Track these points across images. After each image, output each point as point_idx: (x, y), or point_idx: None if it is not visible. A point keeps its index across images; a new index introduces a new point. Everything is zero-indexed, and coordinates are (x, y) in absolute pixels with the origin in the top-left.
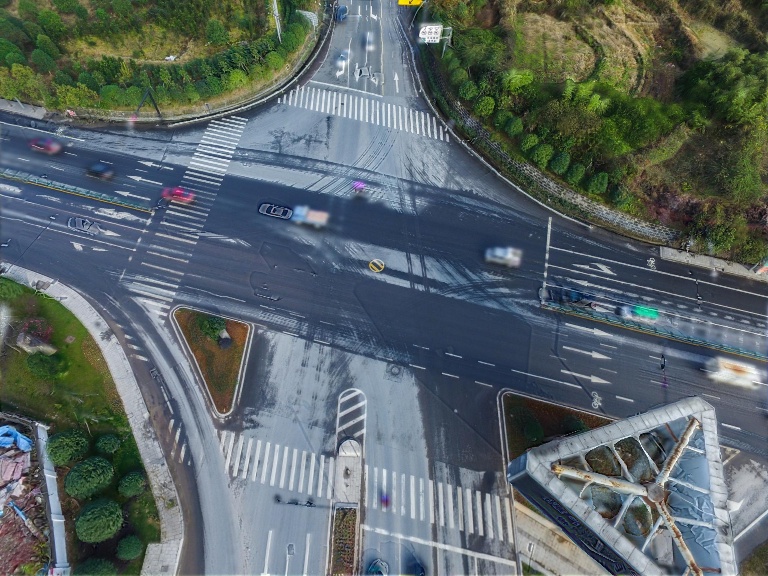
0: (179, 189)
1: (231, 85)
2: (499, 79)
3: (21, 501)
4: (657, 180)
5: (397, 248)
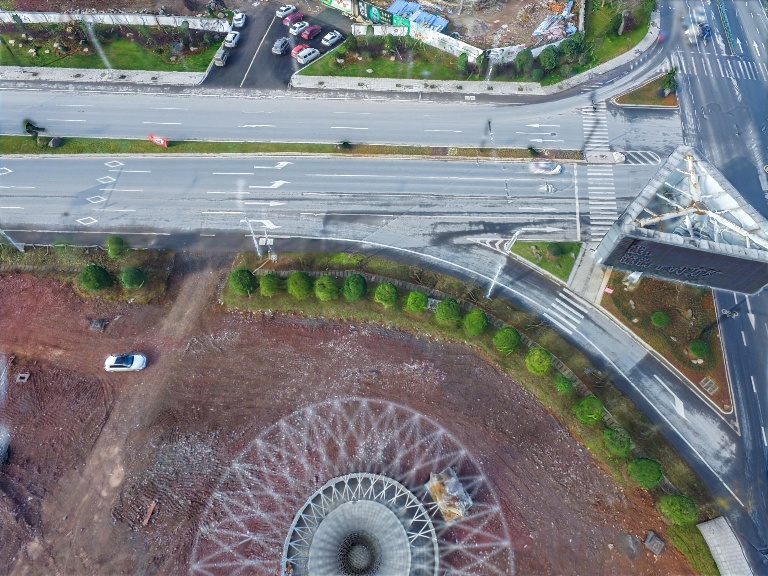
0: (762, 64)
1: None
2: None
3: (546, 39)
4: None
5: None
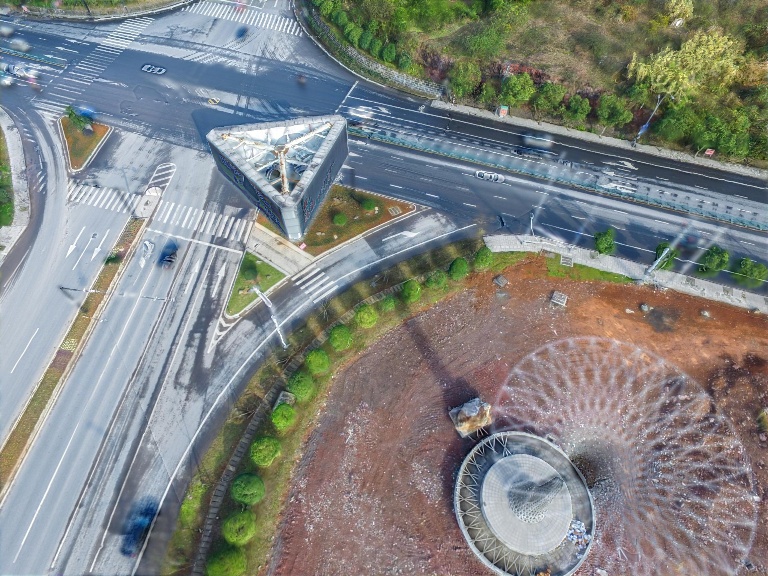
0: (89, 55)
1: None
2: None
3: None
4: (429, 48)
5: (233, 92)
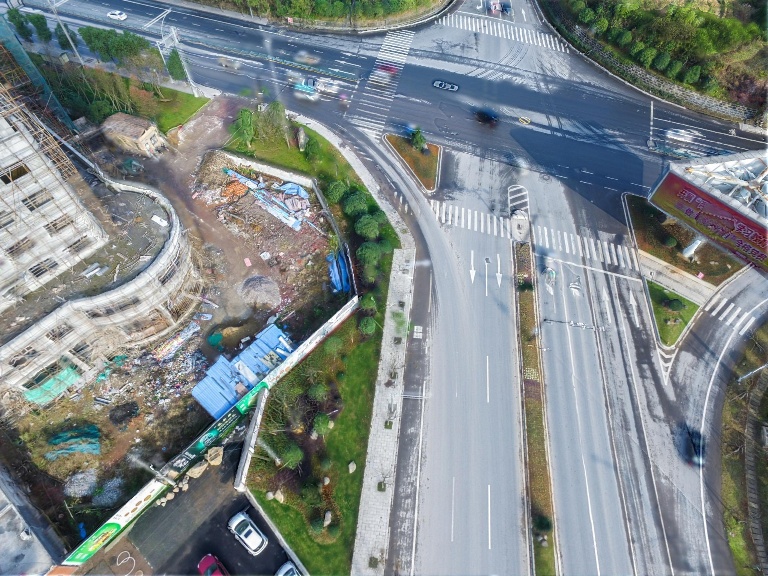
0: (373, 70)
1: (405, 6)
2: (612, 6)
3: (311, 219)
4: (739, 71)
5: (538, 111)
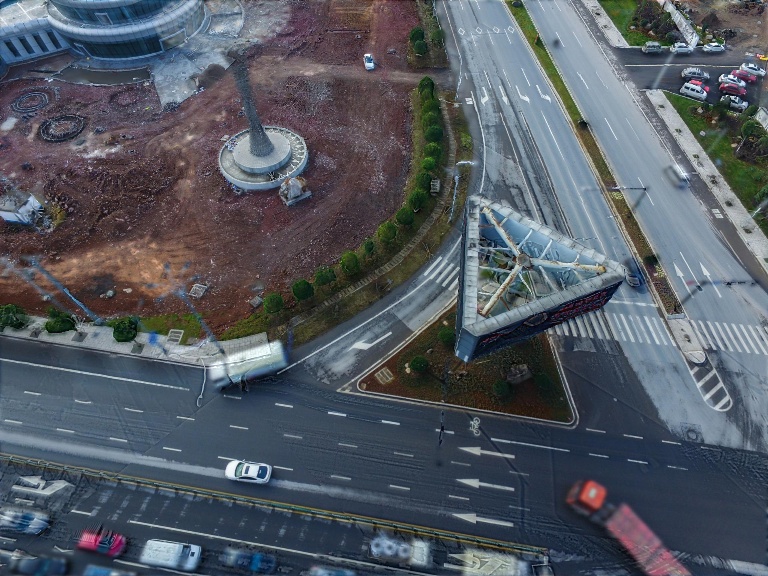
0: None
1: None
2: None
3: None
4: None
5: None
